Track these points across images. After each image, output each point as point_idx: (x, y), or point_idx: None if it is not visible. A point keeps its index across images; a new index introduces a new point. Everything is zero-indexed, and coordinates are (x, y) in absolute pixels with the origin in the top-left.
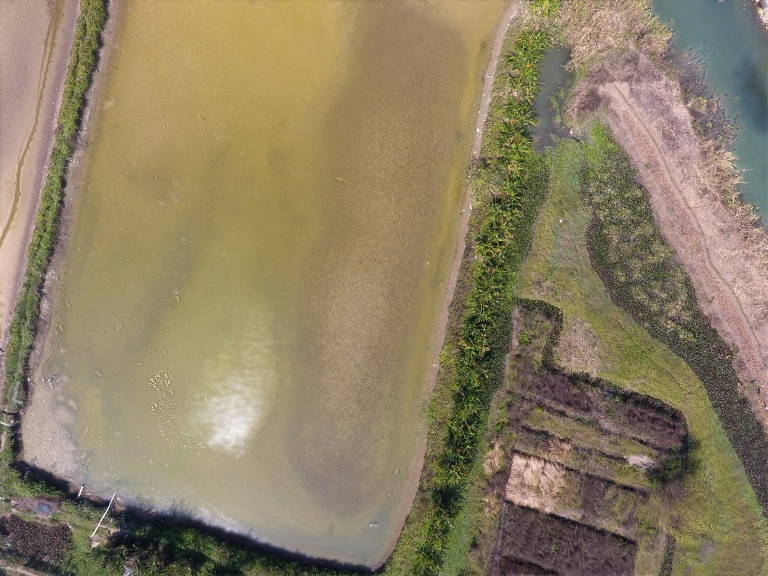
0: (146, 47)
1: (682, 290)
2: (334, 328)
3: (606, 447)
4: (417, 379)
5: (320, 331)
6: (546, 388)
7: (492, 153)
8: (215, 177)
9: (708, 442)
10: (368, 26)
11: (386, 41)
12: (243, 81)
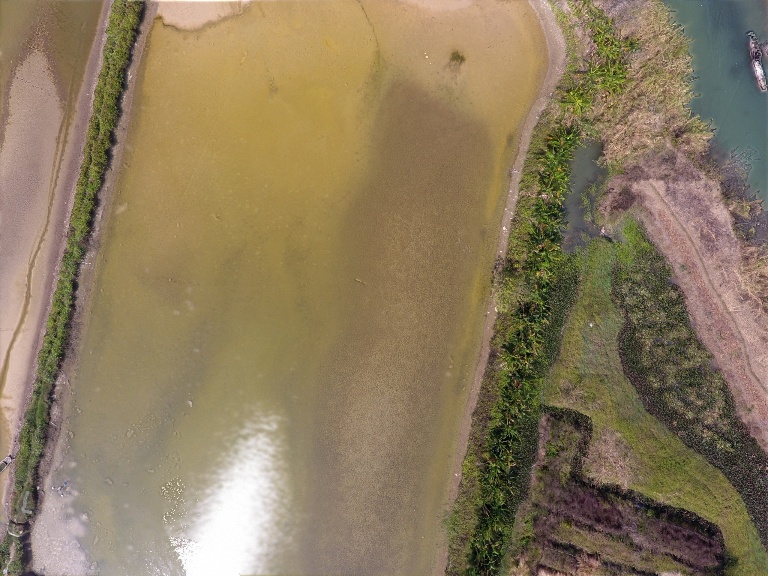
0: (160, 144)
1: (719, 397)
2: (352, 435)
3: (637, 563)
4: (438, 488)
5: (337, 438)
6: (574, 504)
7: (520, 256)
8: (230, 278)
9: (746, 559)
10: (390, 120)
11: (409, 135)
12: (260, 178)
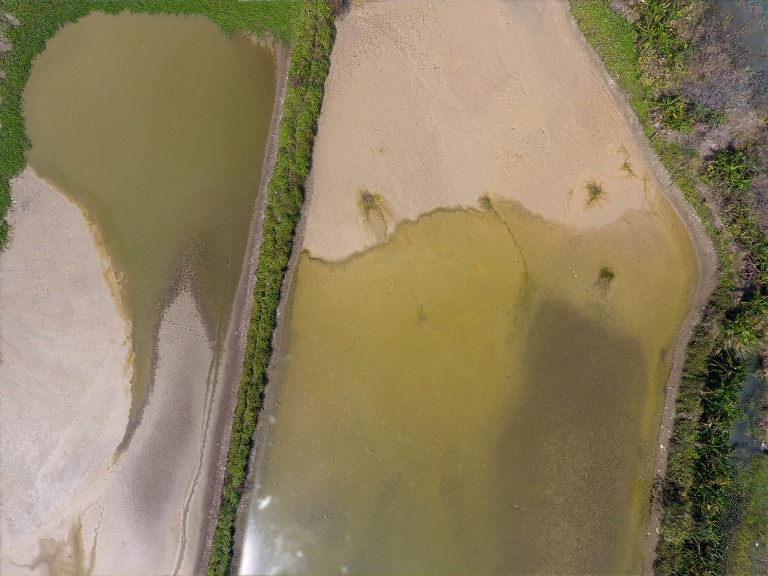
0: (311, 379)
1: None
2: None
3: None
4: None
5: None
6: None
7: (685, 484)
8: (386, 511)
9: None
10: (541, 341)
11: (560, 356)
12: (412, 408)
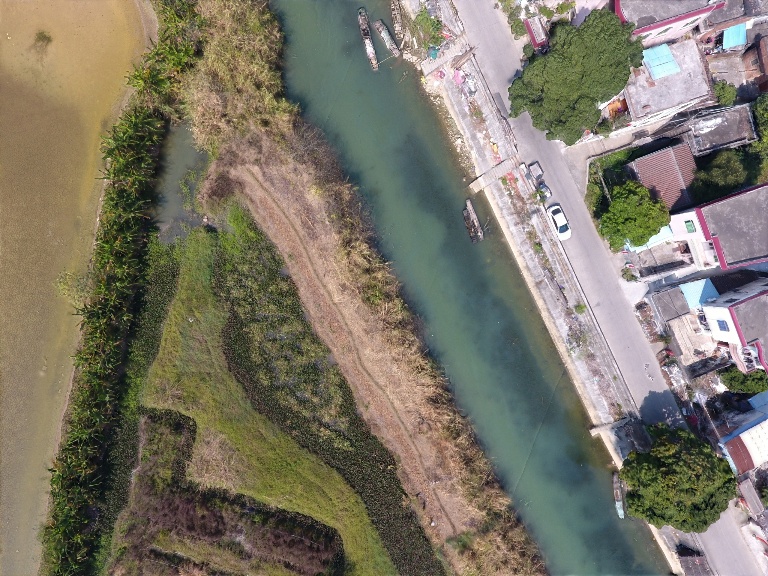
0: None
1: (336, 393)
2: None
3: (248, 571)
4: (34, 498)
5: None
6: (164, 511)
7: None
8: None
9: (365, 564)
10: None
11: None
12: None
